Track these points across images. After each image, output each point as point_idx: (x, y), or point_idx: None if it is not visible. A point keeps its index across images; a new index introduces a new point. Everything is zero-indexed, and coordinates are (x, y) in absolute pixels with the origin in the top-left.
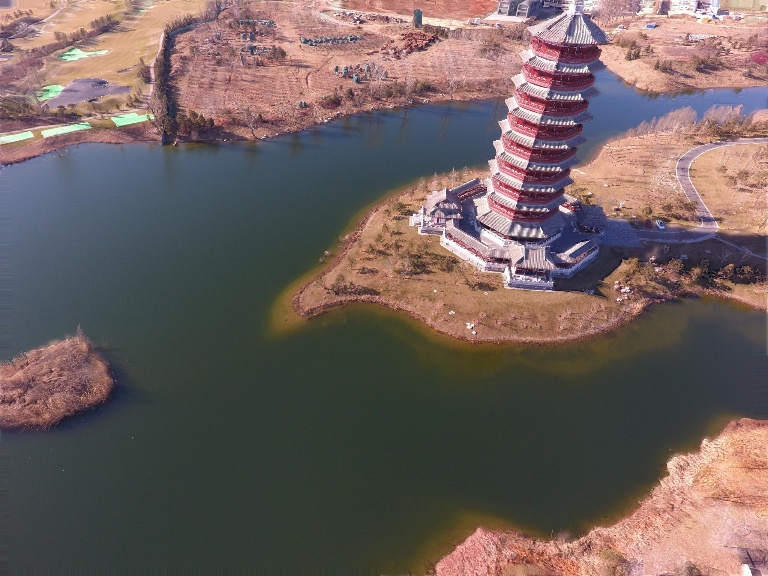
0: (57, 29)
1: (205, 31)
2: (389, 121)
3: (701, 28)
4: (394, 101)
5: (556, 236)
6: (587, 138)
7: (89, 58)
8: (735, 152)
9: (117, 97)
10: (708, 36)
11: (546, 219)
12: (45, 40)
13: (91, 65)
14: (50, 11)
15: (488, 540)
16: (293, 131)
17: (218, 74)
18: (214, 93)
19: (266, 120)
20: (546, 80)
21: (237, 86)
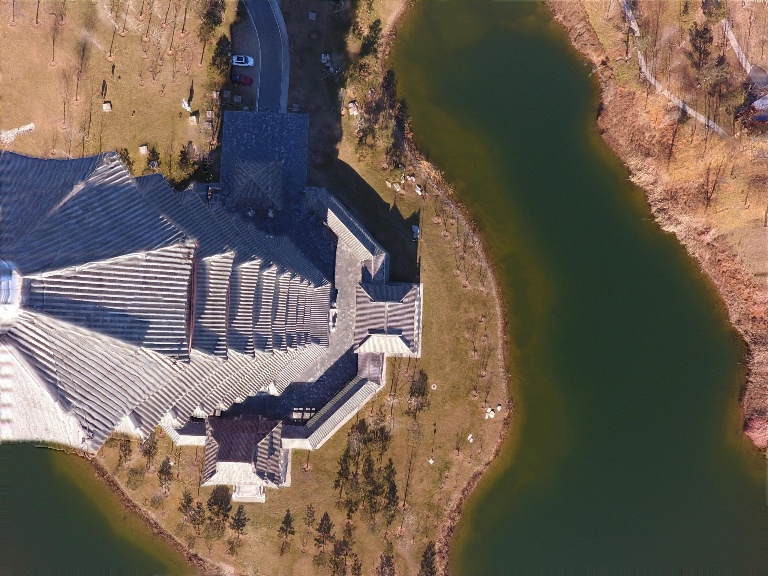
0: None
1: None
2: None
3: None
4: None
5: None
6: None
7: None
8: None
9: None
10: None
11: None
12: None
13: None
14: None
15: (765, 428)
16: None
17: None
18: None
19: None
20: None
21: None
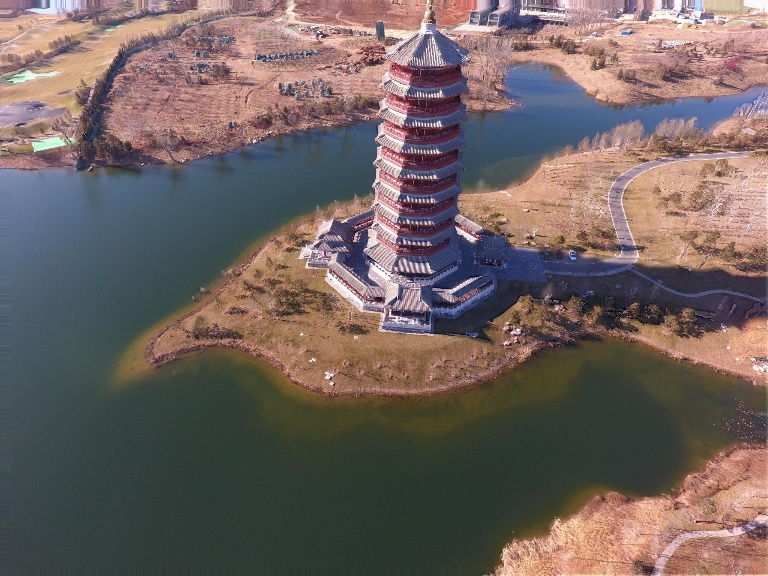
0: (17, 51)
1: (161, 49)
2: (322, 140)
3: (679, 34)
4: (333, 119)
5: (451, 270)
6: (527, 155)
7: (36, 80)
8: (680, 170)
9: (45, 120)
10: (684, 42)
11: (436, 252)
12: (2, 62)
13: (35, 87)
14: (17, 33)
15: None
16: (217, 153)
17: (158, 94)
18: (146, 114)
19: (190, 142)
20: (403, 106)
21: (172, 106)
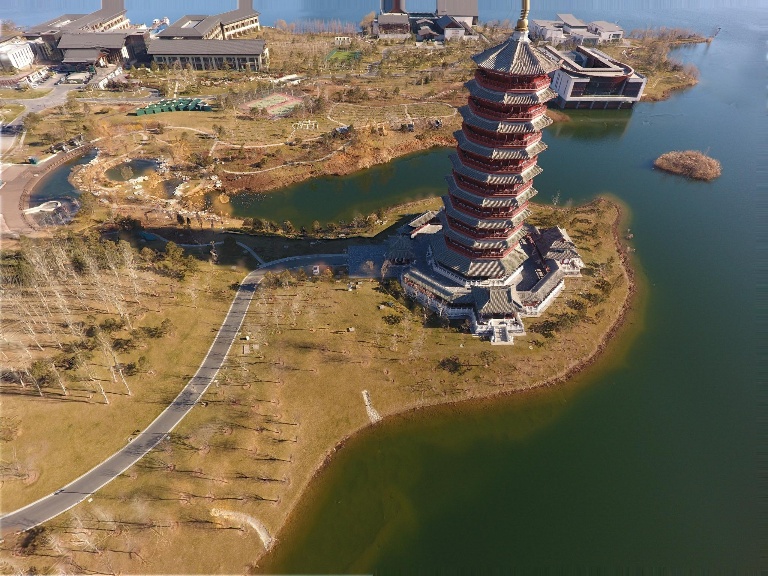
0: None
1: None
2: None
3: None
4: None
5: None
6: None
7: None
8: None
9: None
10: None
11: None
12: None
13: None
14: None
15: None
16: None
17: None
18: None
19: None
20: None
21: None
